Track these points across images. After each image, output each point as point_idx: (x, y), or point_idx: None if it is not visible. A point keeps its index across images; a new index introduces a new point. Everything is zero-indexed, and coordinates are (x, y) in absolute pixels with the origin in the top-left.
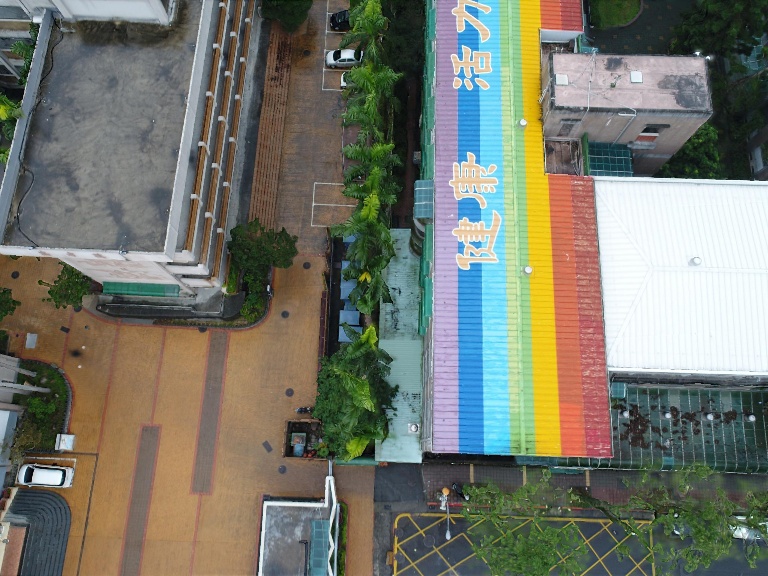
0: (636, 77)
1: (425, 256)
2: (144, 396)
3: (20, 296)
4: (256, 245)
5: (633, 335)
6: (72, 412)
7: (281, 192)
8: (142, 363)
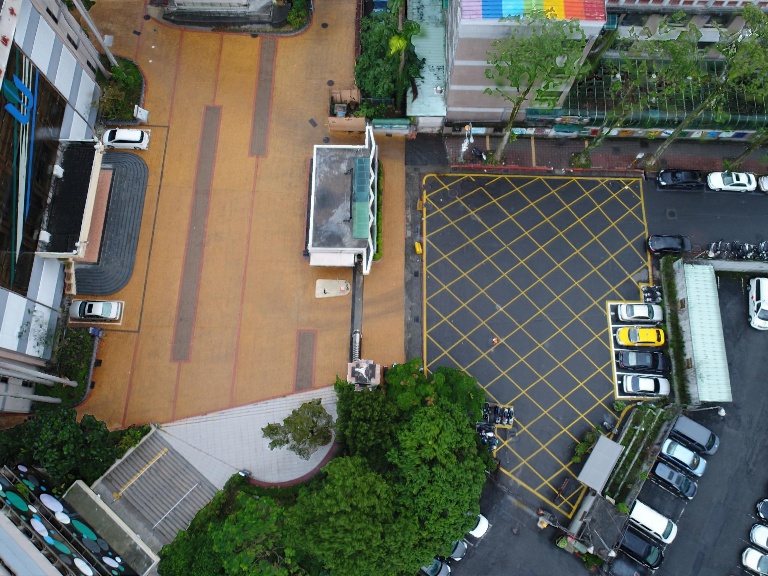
0: None
1: None
2: (206, 84)
3: (97, 8)
4: None
5: None
6: (145, 95)
7: None
8: (203, 60)
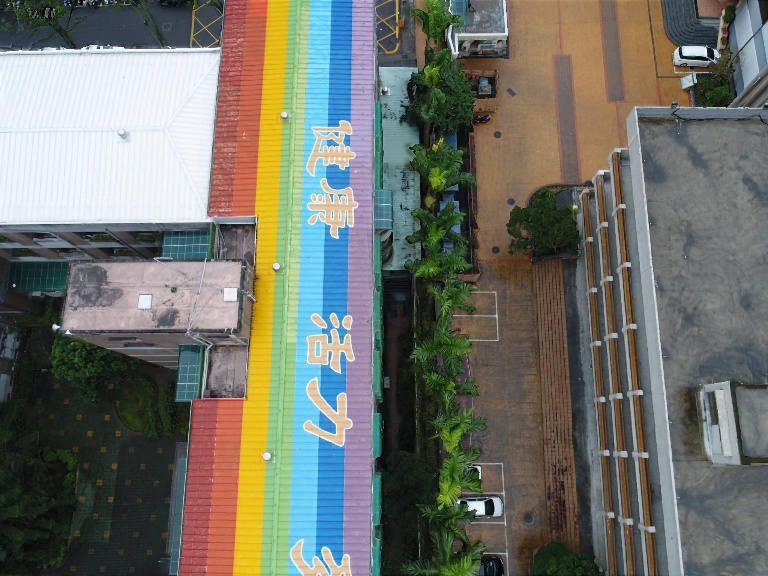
0: (146, 300)
1: (381, 156)
2: None
3: None
4: (550, 213)
5: (193, 76)
6: None
7: (534, 328)
8: None
